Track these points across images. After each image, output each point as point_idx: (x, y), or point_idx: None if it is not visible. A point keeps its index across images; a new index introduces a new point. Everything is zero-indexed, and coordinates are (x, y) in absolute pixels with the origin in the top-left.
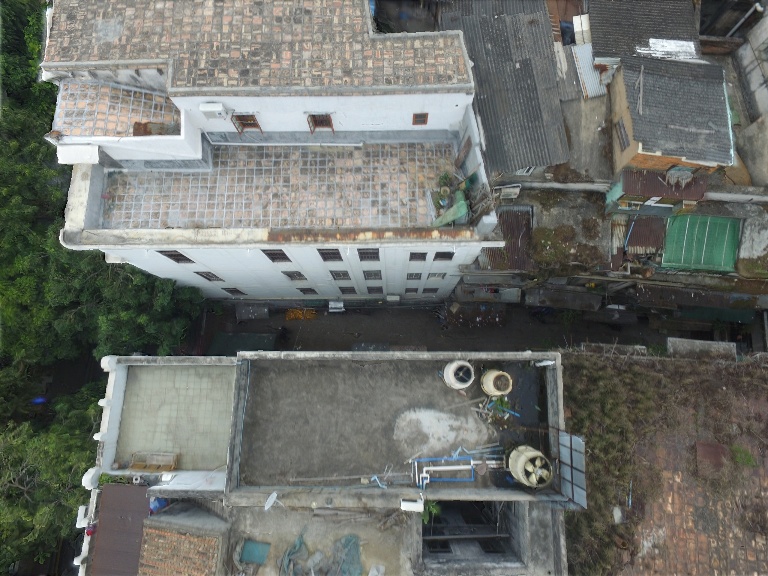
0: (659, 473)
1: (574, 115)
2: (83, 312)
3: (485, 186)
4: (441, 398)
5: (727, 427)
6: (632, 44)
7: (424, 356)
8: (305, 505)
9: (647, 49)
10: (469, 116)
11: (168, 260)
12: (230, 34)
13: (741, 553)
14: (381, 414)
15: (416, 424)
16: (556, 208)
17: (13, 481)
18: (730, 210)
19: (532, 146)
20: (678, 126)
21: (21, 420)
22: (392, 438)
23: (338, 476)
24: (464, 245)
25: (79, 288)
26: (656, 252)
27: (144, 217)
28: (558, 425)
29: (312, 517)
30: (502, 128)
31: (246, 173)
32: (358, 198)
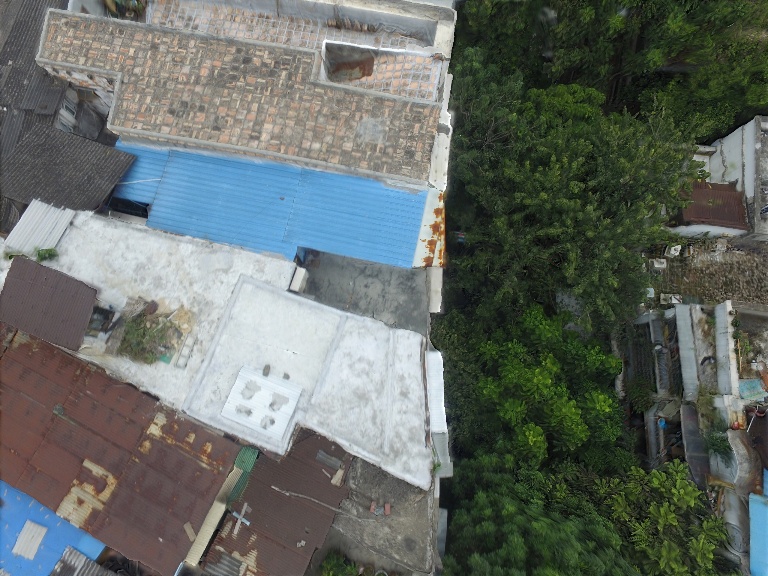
0: None
1: None
2: None
3: None
4: None
5: None
6: None
7: None
8: None
9: None
10: None
11: None
12: (252, 101)
13: None
14: None
15: None
16: None
17: None
18: None
19: (36, 5)
20: None
21: (544, 6)
22: None
23: None
24: None
25: None
26: None
27: (395, 48)
28: None
29: None
30: None
31: None
32: None
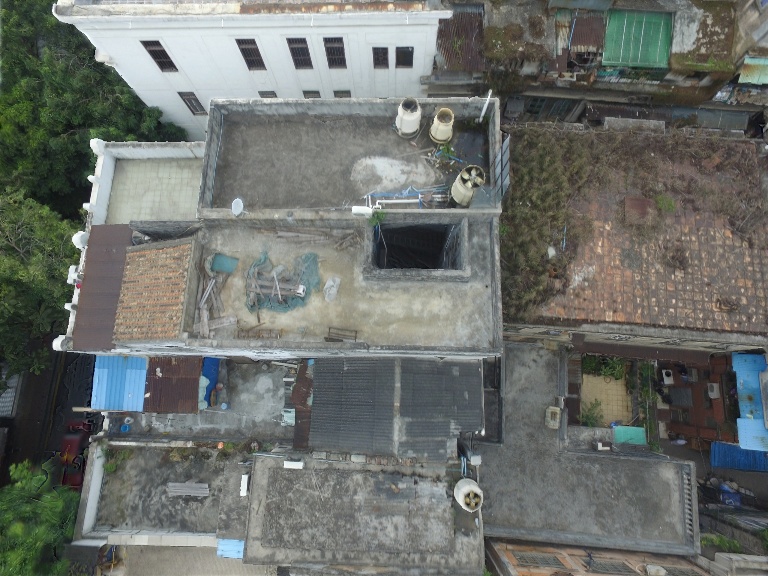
0: (591, 221)
1: None
2: (76, 138)
3: None
4: (394, 148)
5: (653, 185)
6: None
7: (377, 101)
8: (269, 217)
9: None
10: None
11: (153, 63)
12: None
13: (661, 285)
14: (340, 160)
15: (371, 168)
16: (505, 6)
17: (10, 240)
18: (662, 5)
19: None
20: None
21: None
22: (349, 179)
23: (300, 208)
24: (416, 13)
25: (72, 102)
26: (597, 51)
27: None
28: (495, 155)
29: (276, 238)
30: None
31: None
32: None
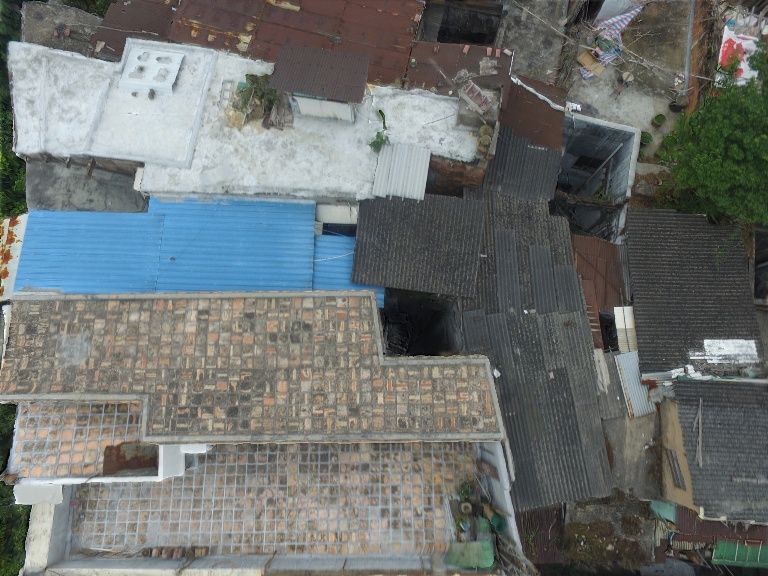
0: None
1: (617, 432)
2: None
3: (517, 552)
4: None
5: None
6: (684, 349)
7: None
8: None
9: (702, 354)
10: (497, 452)
11: None
12: (216, 358)
13: None
14: None
15: None
16: (592, 505)
17: None
18: None
19: (569, 475)
20: (744, 478)
21: None
22: None
23: None
24: None
25: None
26: (706, 547)
27: (119, 530)
28: None
29: None
30: (534, 452)
31: (237, 470)
32: (365, 505)
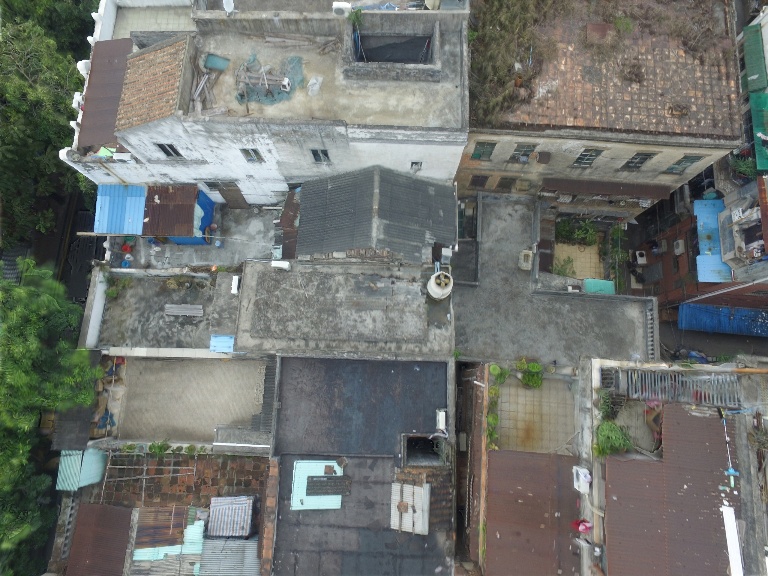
0: (555, 42)
1: None
2: (80, 7)
3: None
4: None
5: (614, 12)
6: None
7: None
8: (257, 17)
9: None
10: None
11: None
12: None
13: (619, 95)
14: None
15: None
16: None
17: (20, 66)
18: None
19: None
20: None
21: None
22: None
23: None
24: None
25: None
26: None
27: None
28: None
29: (264, 43)
30: None
31: None
32: None
